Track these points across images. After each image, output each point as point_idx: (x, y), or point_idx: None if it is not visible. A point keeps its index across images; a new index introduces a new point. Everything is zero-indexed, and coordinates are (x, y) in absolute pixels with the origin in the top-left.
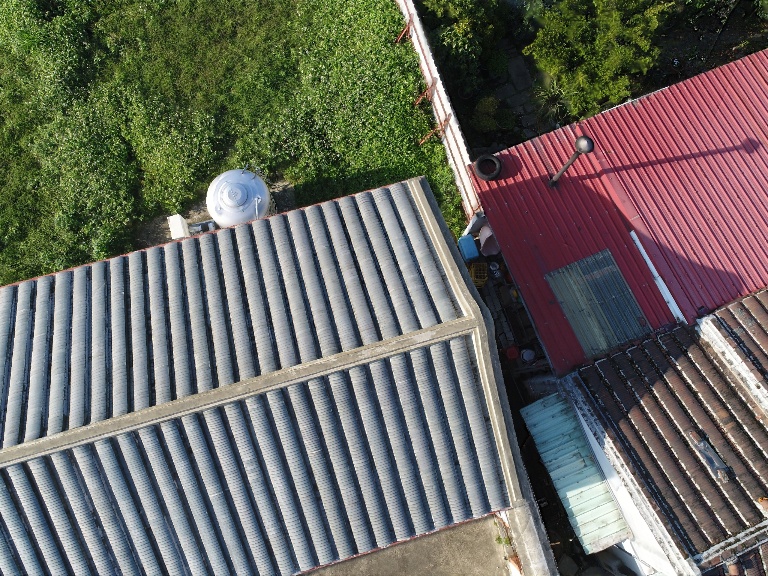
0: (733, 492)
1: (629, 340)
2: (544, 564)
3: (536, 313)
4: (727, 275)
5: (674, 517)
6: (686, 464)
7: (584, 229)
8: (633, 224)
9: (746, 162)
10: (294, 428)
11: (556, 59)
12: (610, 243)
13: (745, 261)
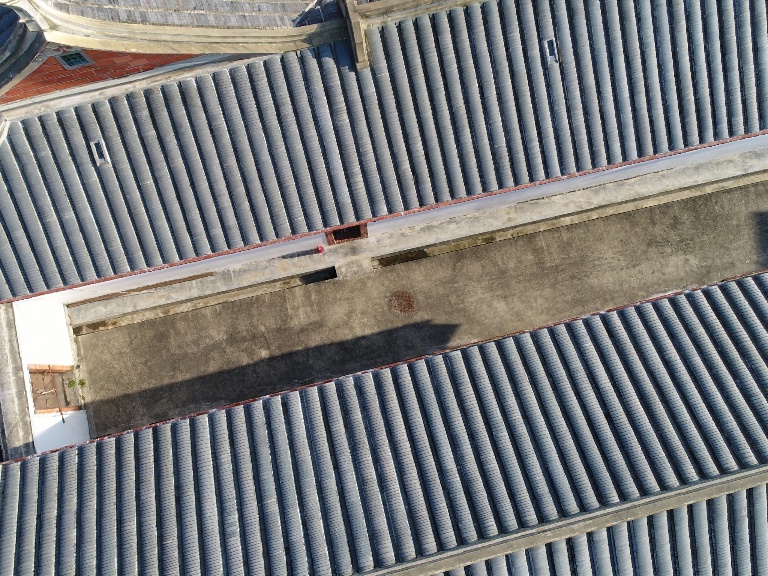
0: None
1: None
2: (2, 393)
3: None
4: None
5: None
6: None
7: None
8: None
9: None
10: (185, 570)
11: None
12: None
13: None
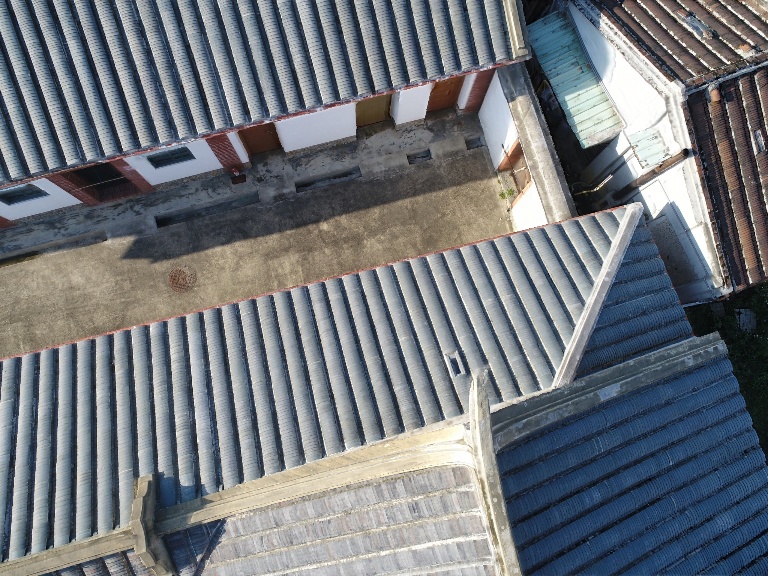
0: (716, 44)
1: None
2: (544, 143)
3: None
4: None
5: (662, 62)
6: (674, 31)
7: None
8: None
9: None
10: None
11: None
12: None
13: None
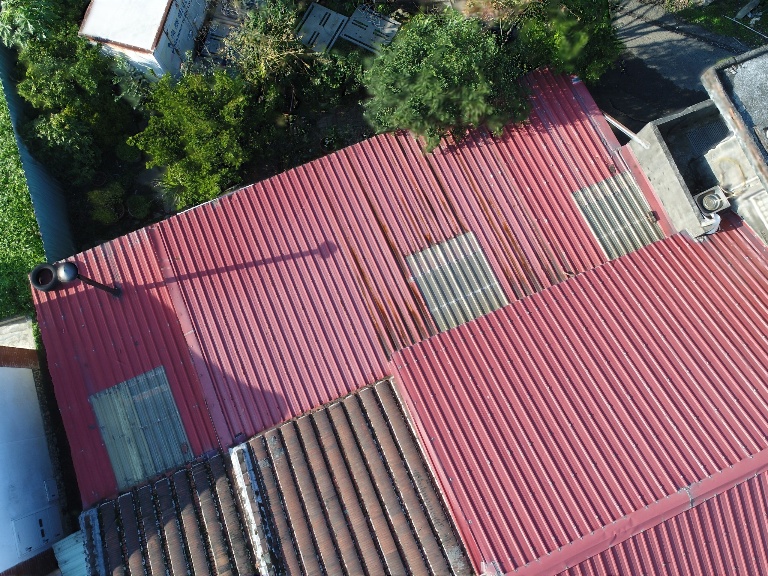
0: None
1: (166, 469)
2: None
3: (73, 439)
4: (274, 397)
5: None
6: None
7: (141, 344)
8: (186, 340)
9: (319, 268)
10: None
11: (157, 151)
12: (166, 359)
13: (296, 381)
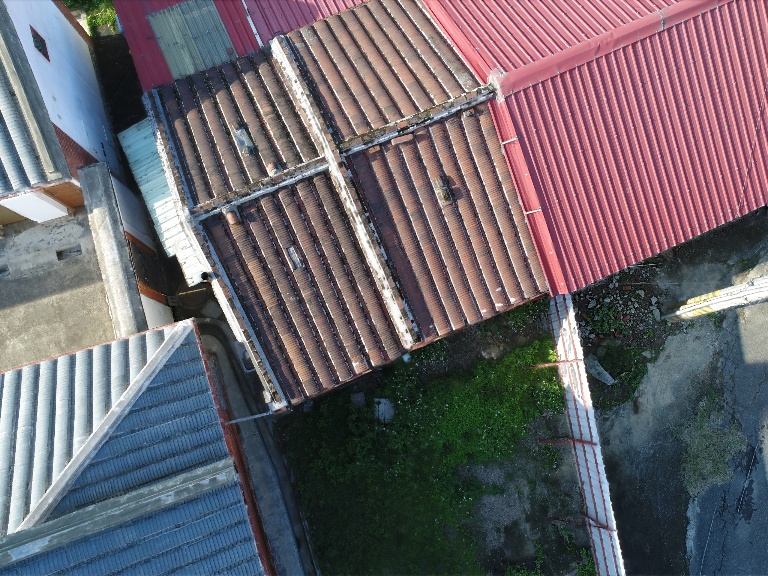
0: (250, 162)
1: None
2: (115, 256)
3: (134, 47)
4: (306, 5)
5: (192, 183)
6: (219, 146)
7: None
8: None
9: None
10: None
11: None
12: None
13: None
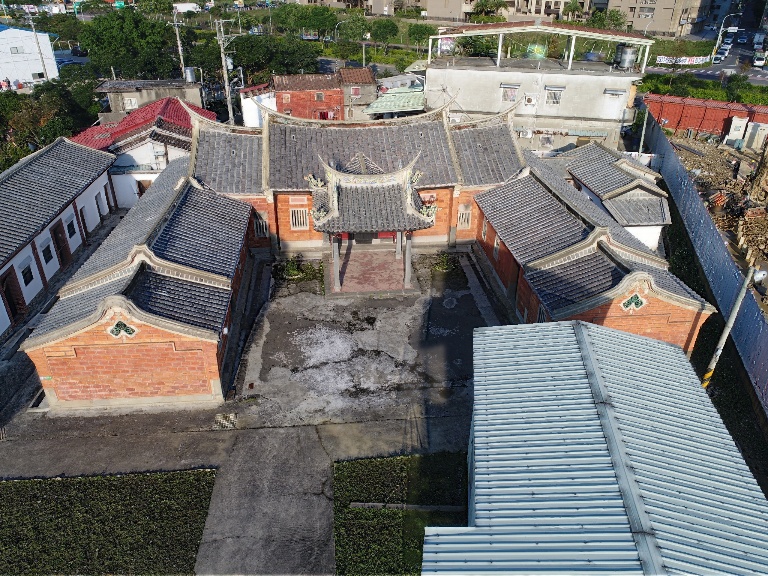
0: None
1: None
2: None
3: None
4: None
5: None
6: None
7: None
8: None
9: None
10: None
11: None
12: None
13: None
